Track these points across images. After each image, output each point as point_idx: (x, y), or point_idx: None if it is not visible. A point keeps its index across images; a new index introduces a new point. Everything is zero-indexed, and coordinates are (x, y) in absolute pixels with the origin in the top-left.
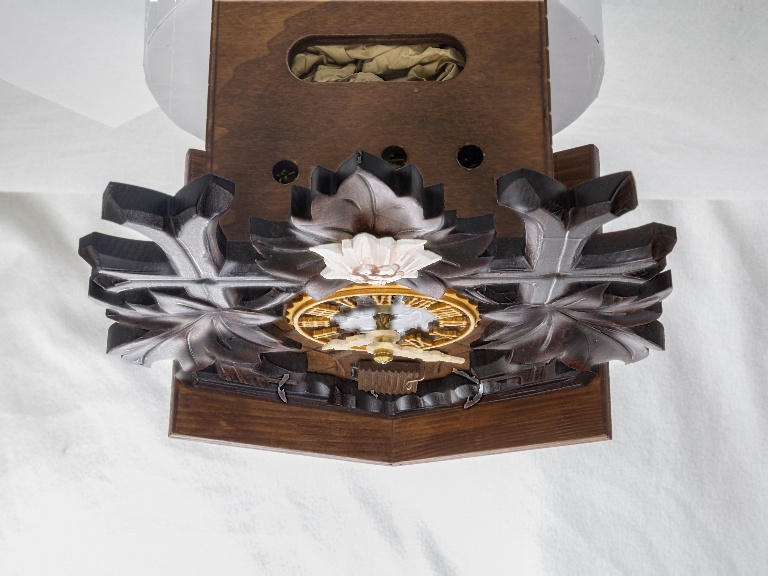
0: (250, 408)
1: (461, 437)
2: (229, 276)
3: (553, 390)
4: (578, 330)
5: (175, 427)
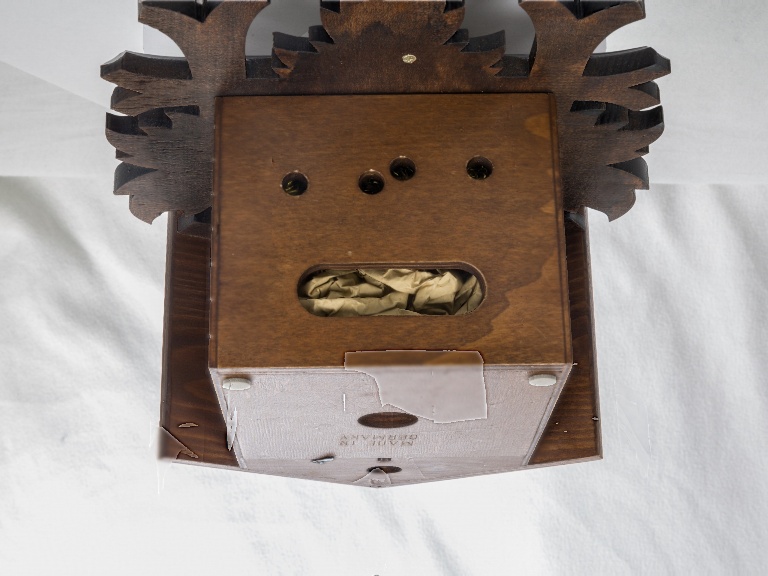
0: None
1: None
2: None
3: None
4: None
5: None
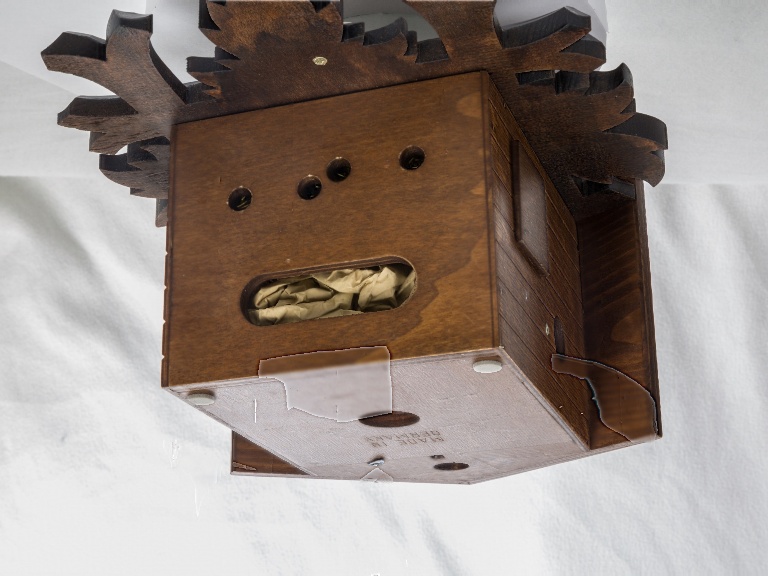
0: None
1: None
2: None
3: None
4: None
5: None
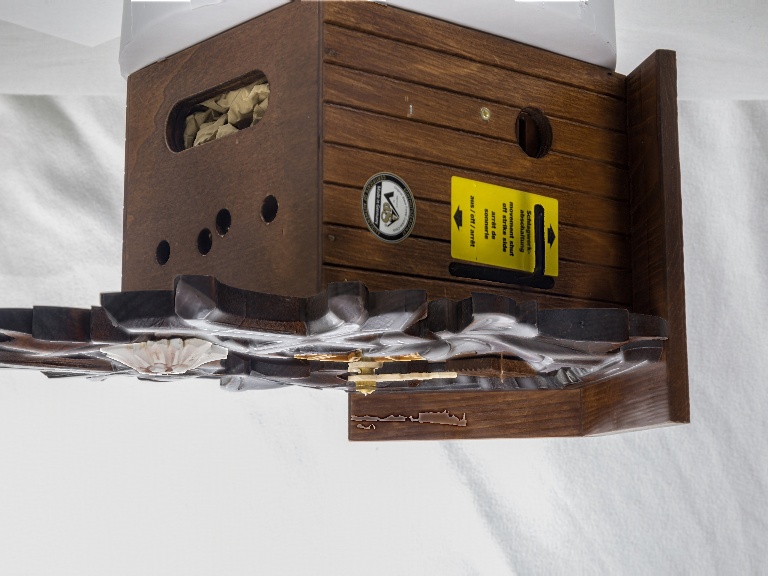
0: (422, 403)
1: (608, 413)
2: (120, 370)
3: (636, 366)
4: (511, 339)
5: (350, 434)
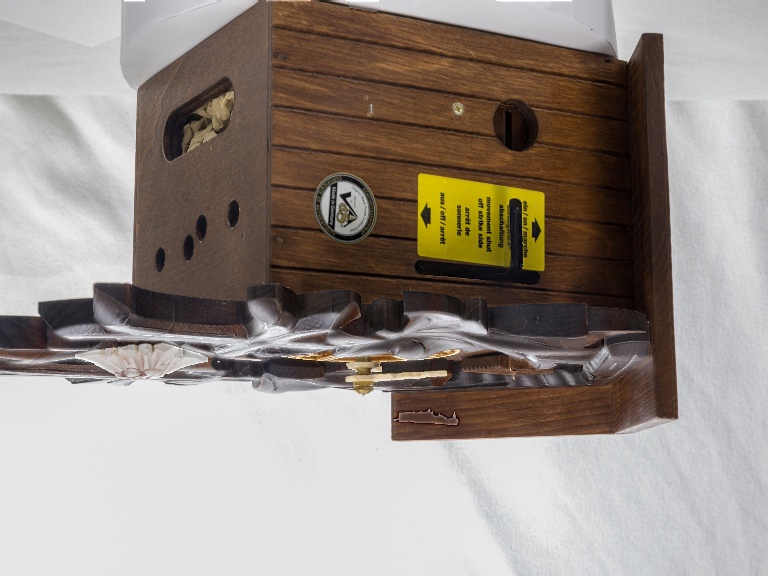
0: (459, 401)
1: (625, 409)
2: None
3: None
4: (477, 336)
5: (392, 434)
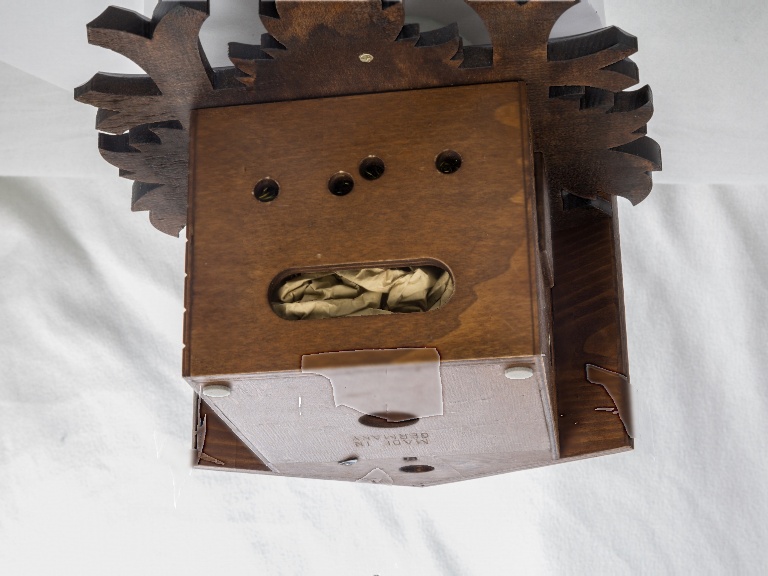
0: None
1: None
2: None
3: None
4: None
5: None
